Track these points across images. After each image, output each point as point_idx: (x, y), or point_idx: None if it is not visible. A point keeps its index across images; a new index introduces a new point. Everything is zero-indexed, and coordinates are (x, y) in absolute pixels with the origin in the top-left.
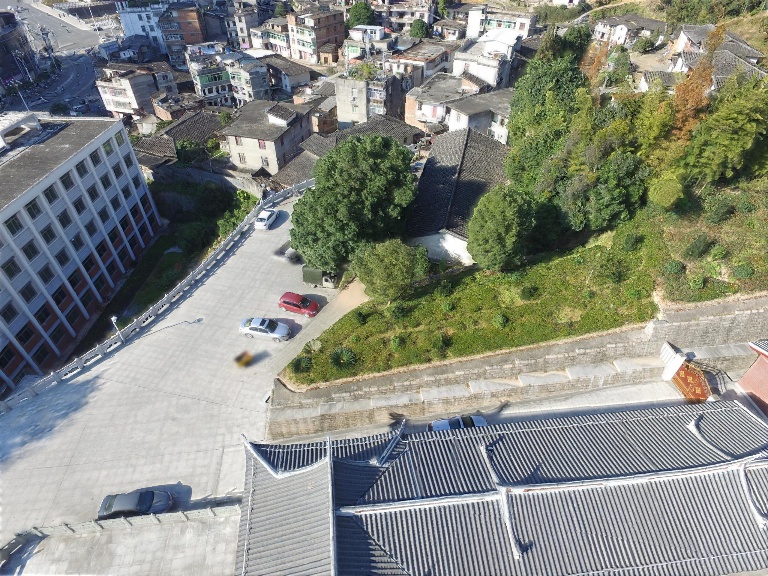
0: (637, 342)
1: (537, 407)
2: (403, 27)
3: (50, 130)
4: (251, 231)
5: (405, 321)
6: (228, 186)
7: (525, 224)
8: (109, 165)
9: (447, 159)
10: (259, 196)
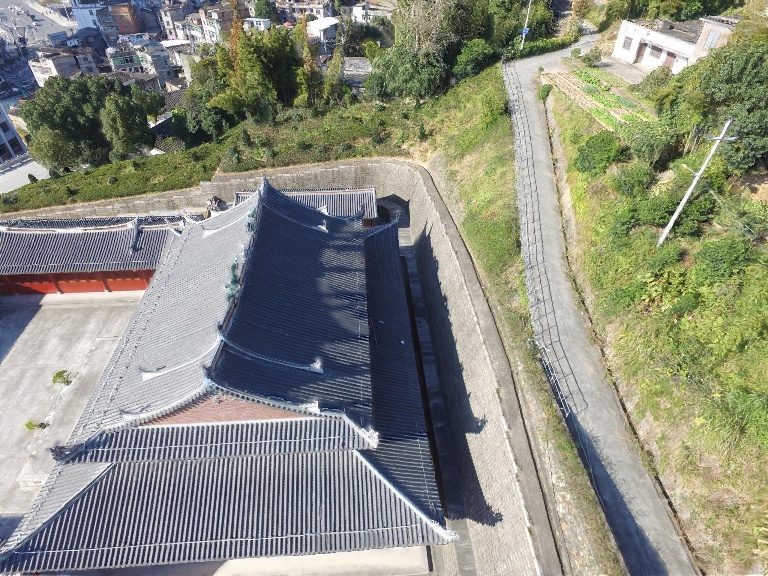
0: (193, 195)
1: None
2: None
3: None
4: None
5: (57, 181)
6: None
7: (129, 120)
8: None
9: None
10: None
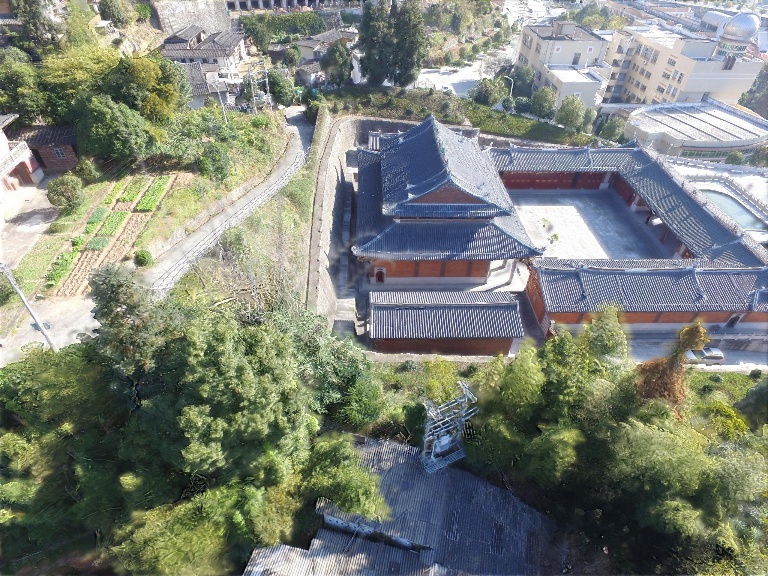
0: None
1: None
2: None
3: None
4: None
5: None
6: None
7: (760, 384)
8: None
9: None
10: None
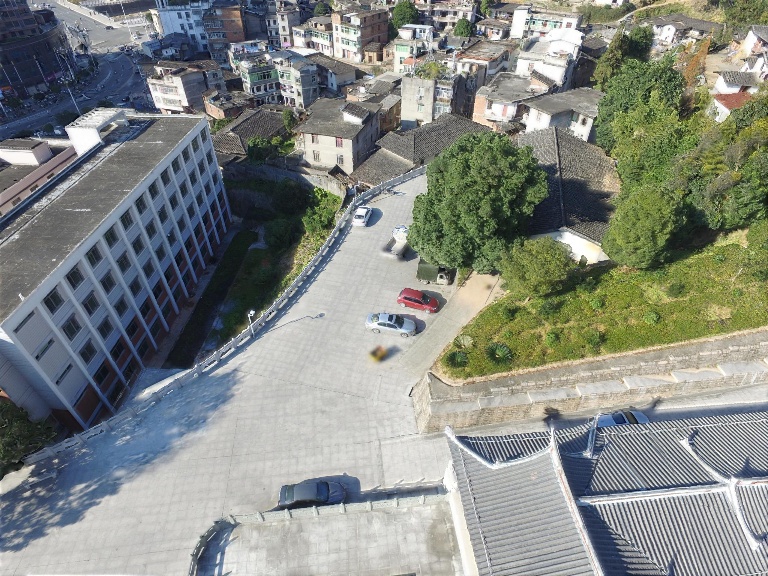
0: None
1: (691, 403)
2: (445, 26)
3: (138, 127)
4: (349, 228)
5: (555, 317)
6: (304, 183)
7: (678, 222)
8: (196, 162)
9: (541, 158)
10: (338, 193)
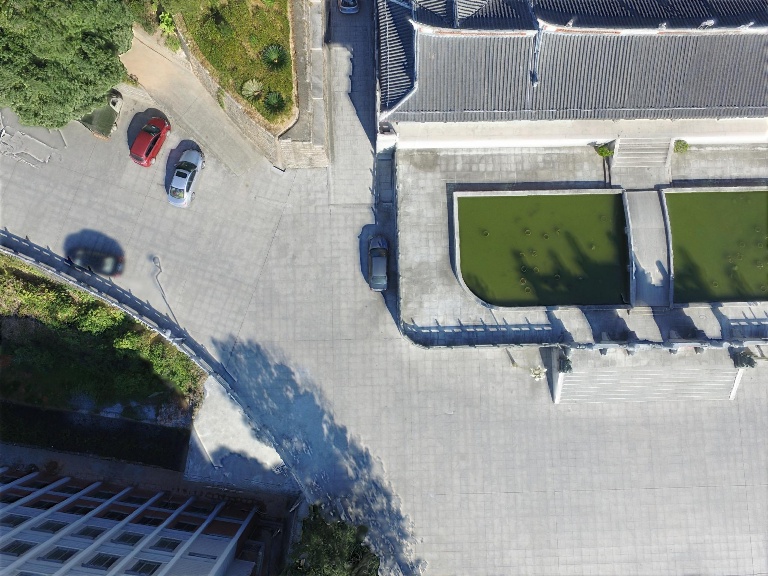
0: None
1: None
2: None
3: None
4: None
5: None
6: None
7: None
8: None
9: None
10: None
